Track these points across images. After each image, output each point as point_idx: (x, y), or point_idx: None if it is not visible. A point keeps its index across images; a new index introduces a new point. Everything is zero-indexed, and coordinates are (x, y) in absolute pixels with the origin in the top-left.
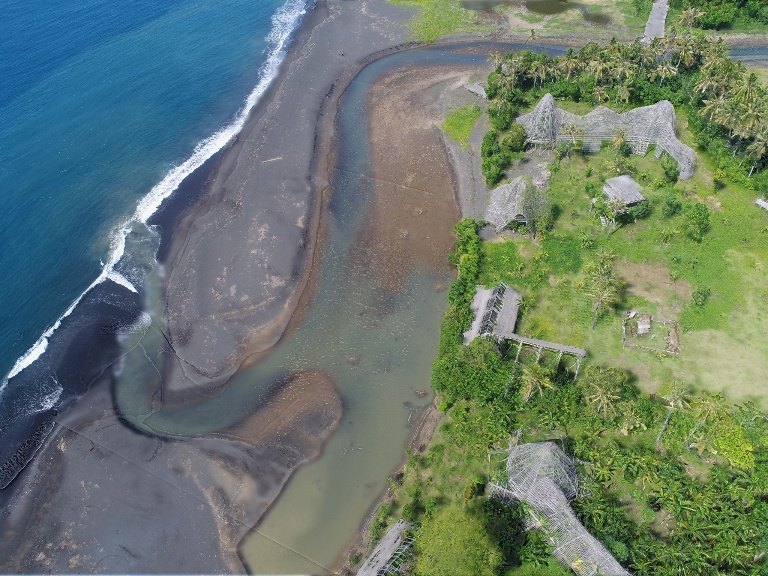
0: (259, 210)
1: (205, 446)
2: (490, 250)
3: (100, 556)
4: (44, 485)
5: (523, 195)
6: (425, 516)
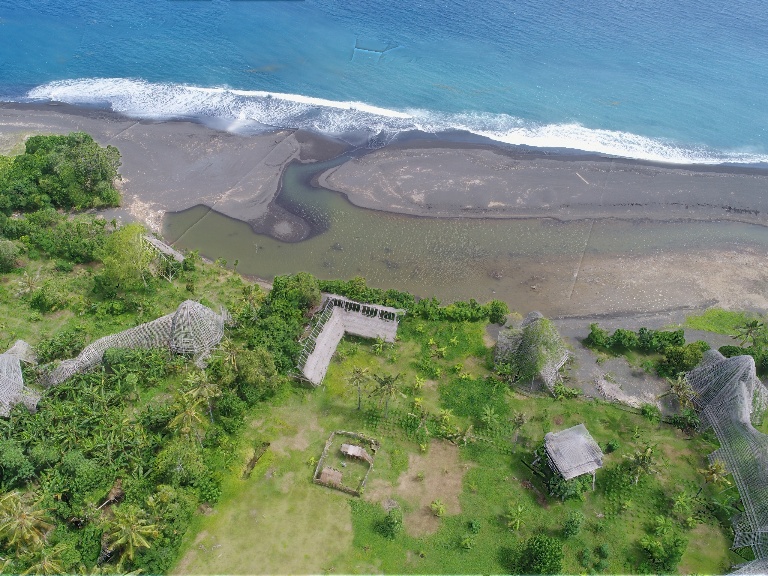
0: (504, 178)
1: (272, 183)
2: (471, 332)
3: (210, 157)
4: (257, 132)
5: (526, 330)
6: (192, 278)
